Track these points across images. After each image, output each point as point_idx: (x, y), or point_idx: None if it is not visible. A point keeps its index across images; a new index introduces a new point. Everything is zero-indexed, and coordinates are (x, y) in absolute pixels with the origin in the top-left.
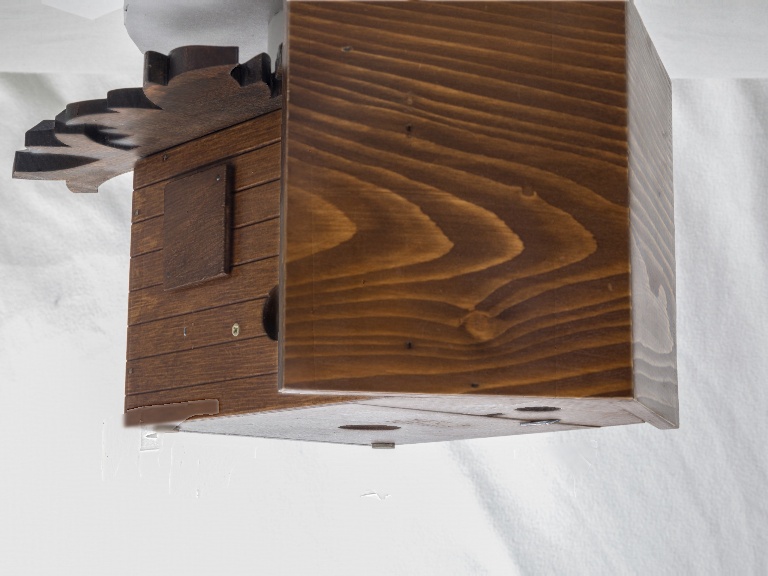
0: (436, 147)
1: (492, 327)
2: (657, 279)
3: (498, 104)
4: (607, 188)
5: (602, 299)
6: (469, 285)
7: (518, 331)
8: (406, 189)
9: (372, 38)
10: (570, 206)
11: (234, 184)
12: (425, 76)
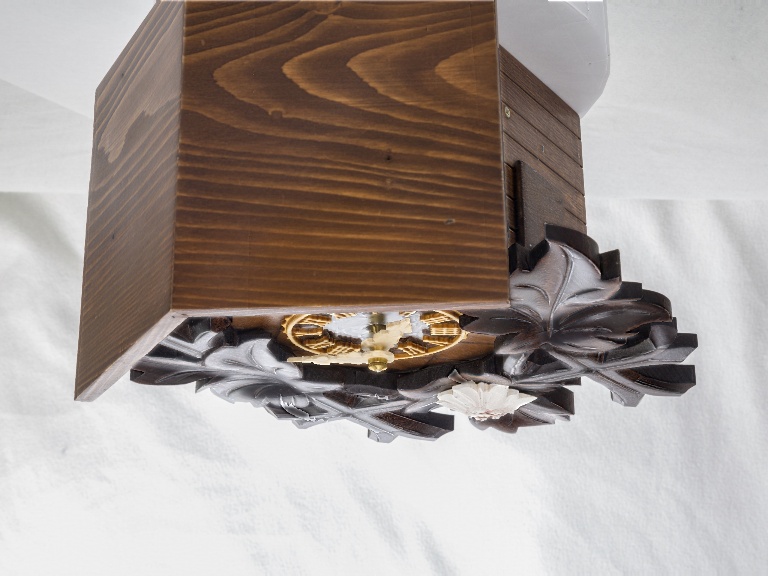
0: (363, 144)
1: (312, 3)
2: (127, 146)
3: (304, 187)
4: (201, 124)
5: (211, 32)
6: (333, 34)
7: (289, 2)
8: (391, 106)
9: (426, 234)
10: (237, 106)
11: (517, 238)
12: (374, 205)
